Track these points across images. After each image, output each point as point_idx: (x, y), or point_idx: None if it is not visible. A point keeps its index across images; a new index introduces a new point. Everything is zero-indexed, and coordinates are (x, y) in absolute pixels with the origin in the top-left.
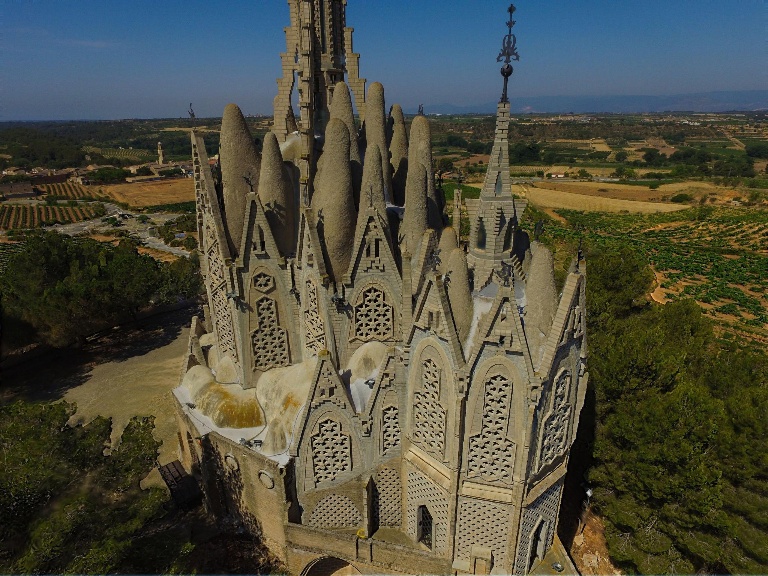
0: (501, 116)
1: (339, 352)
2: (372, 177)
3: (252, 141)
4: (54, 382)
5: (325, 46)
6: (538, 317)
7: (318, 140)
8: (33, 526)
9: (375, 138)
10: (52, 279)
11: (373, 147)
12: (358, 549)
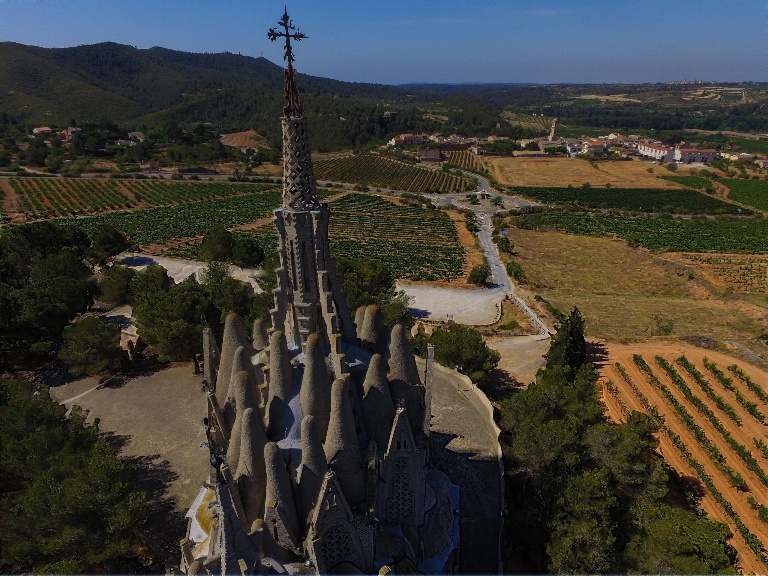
0: None
1: None
2: (243, 435)
3: (242, 342)
4: None
5: (297, 286)
6: None
7: (291, 353)
8: (65, 528)
9: (305, 381)
10: None
11: (244, 414)
12: None
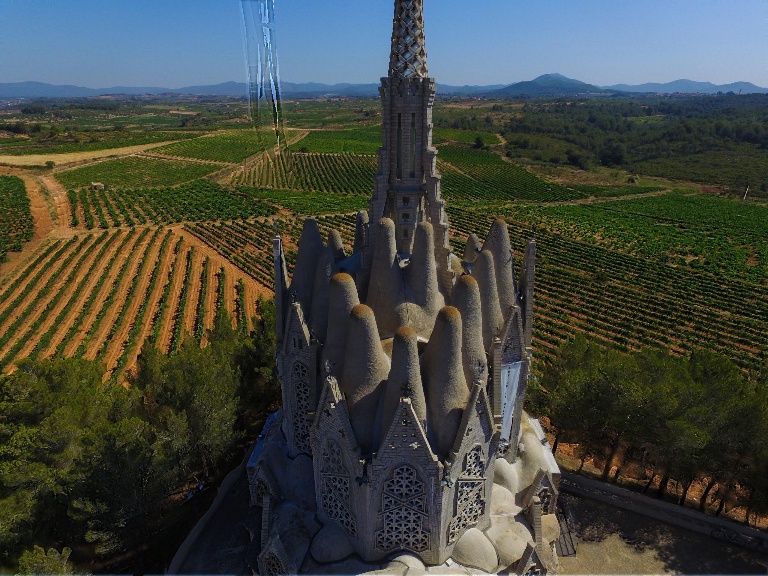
0: None
1: None
2: None
3: None
4: None
5: None
6: None
7: None
8: None
9: None
10: None
11: None
12: None
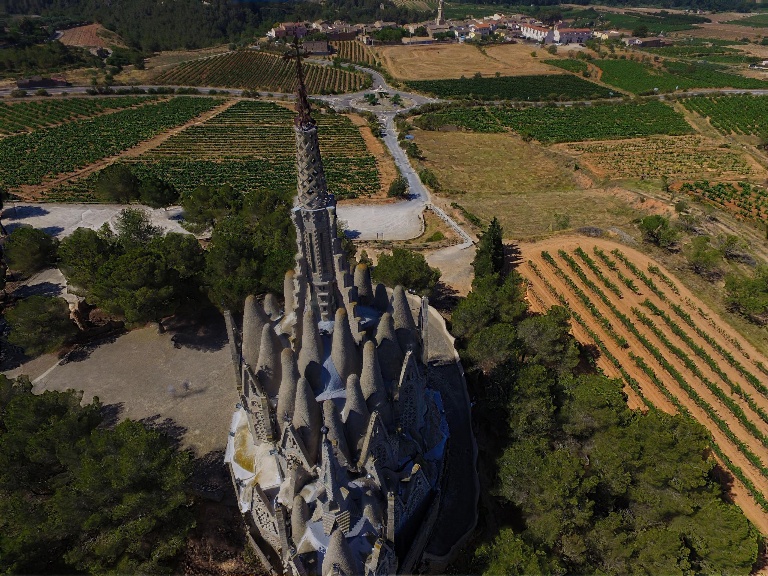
0: (324, 449)
1: (284, 470)
2: (299, 398)
3: (263, 319)
4: (222, 333)
5: (315, 269)
6: (326, 567)
7: None
8: (124, 495)
9: (336, 346)
10: (234, 262)
11: (300, 383)
12: (272, 573)
